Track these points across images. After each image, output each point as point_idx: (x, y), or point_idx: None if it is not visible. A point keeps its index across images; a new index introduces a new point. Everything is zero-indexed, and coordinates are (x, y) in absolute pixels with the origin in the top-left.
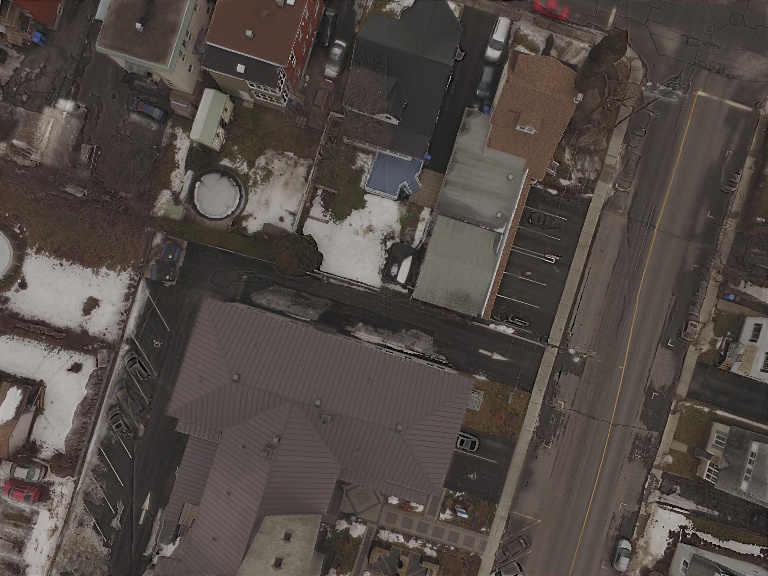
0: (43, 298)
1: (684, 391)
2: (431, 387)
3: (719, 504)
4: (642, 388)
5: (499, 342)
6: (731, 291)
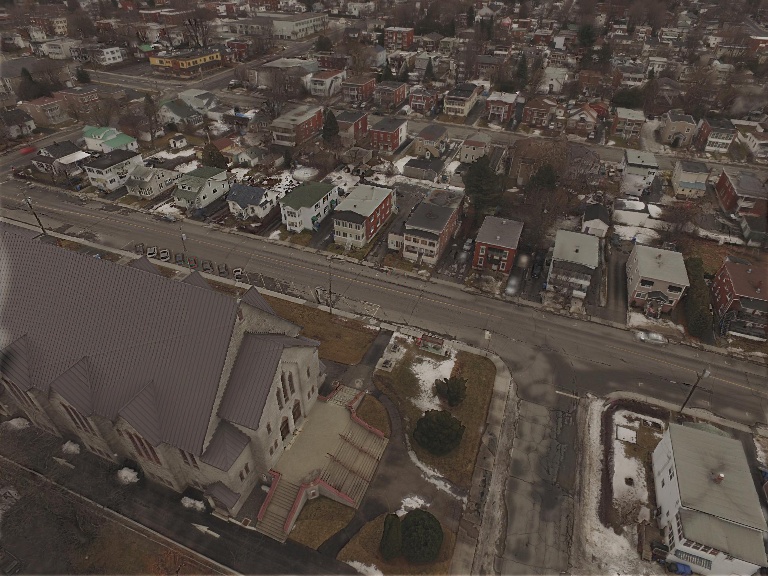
0: None
1: None
2: None
3: (169, 196)
4: None
5: None
6: (75, 187)
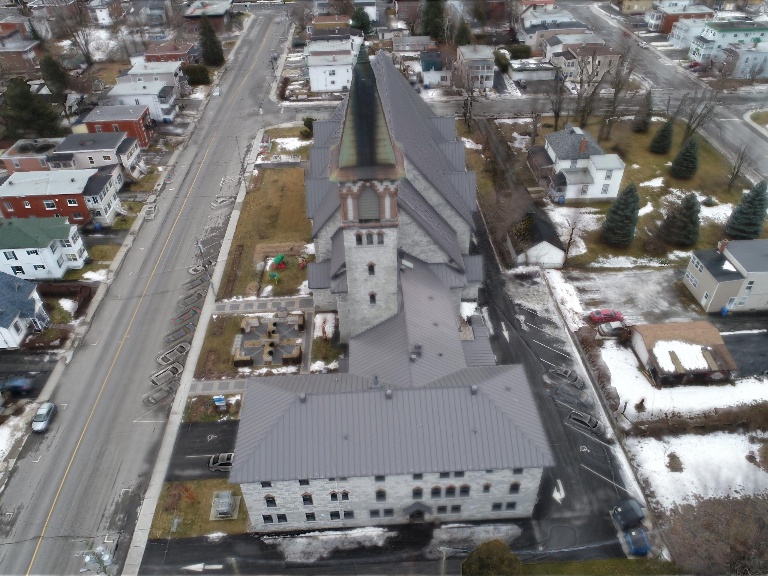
0: (723, 455)
1: None
2: (278, 455)
3: None
4: None
5: None
6: None
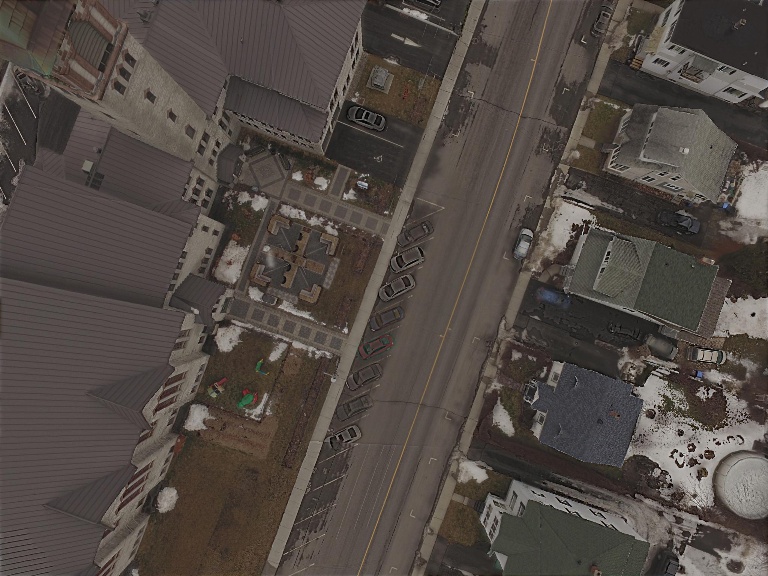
0: None
1: (595, 88)
2: None
3: (624, 202)
4: (553, 82)
5: (412, 28)
6: None
